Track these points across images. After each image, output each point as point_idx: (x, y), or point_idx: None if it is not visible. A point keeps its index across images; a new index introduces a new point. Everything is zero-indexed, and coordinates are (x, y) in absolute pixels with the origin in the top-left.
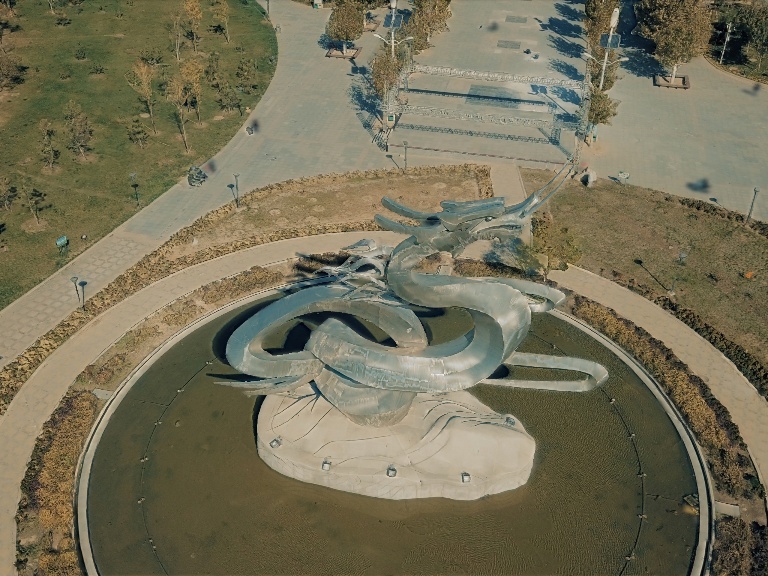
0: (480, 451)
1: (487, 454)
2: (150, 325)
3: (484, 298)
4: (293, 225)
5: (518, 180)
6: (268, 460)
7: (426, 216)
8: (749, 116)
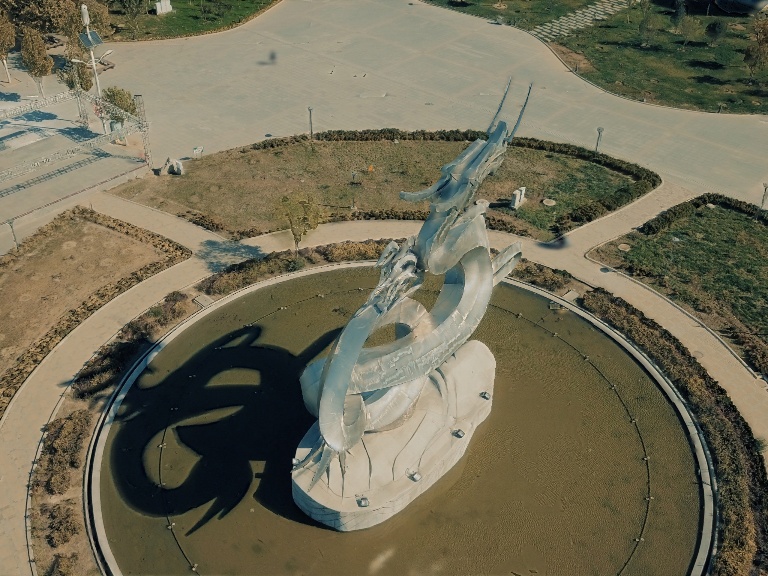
0: (474, 371)
1: (477, 370)
2: (47, 562)
3: (476, 235)
4: (1, 369)
5: (123, 201)
6: (364, 523)
7: (436, 189)
8: (188, 68)
